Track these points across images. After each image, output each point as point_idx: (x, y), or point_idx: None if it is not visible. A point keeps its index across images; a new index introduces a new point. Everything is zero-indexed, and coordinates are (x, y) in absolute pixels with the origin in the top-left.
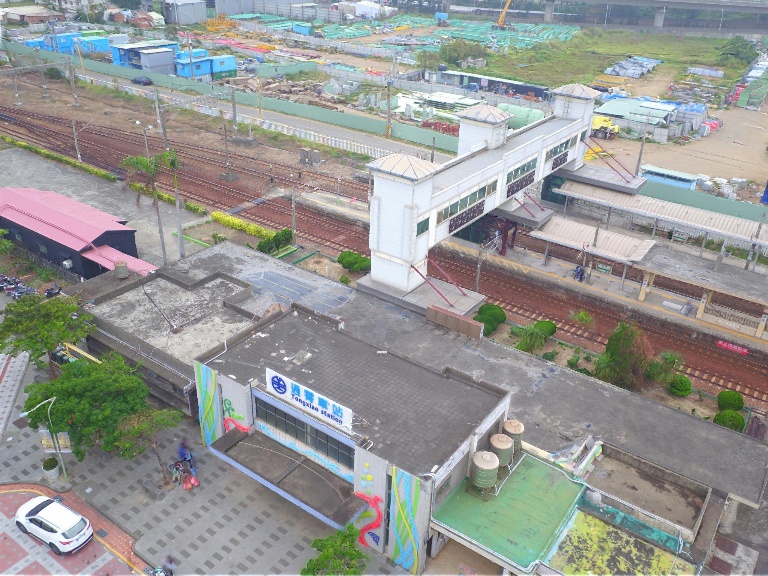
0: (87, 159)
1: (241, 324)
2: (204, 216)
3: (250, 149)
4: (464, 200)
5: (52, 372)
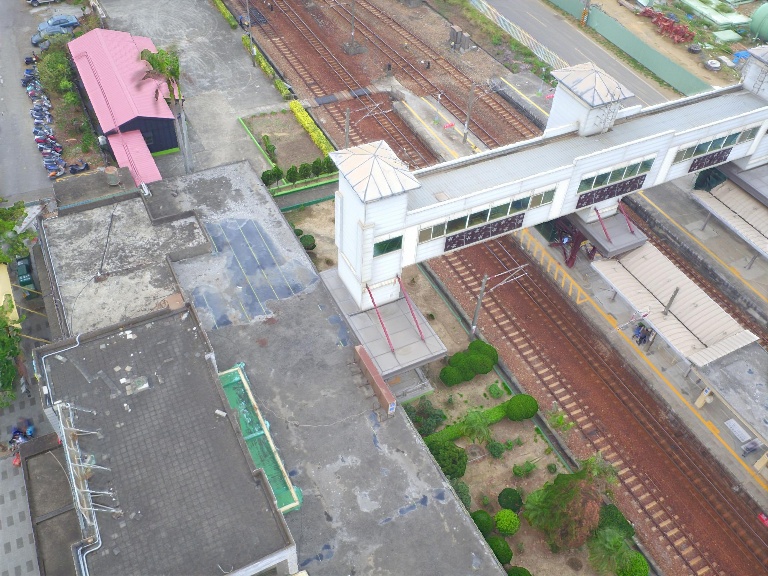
0: None
1: (163, 292)
2: (287, 101)
3: (408, 9)
4: (482, 213)
5: None
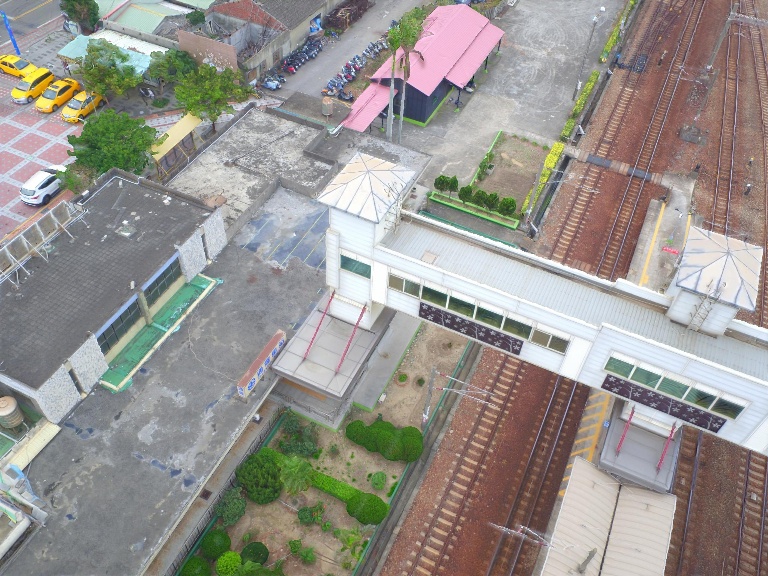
0: (652, 32)
1: (246, 199)
2: (561, 142)
3: None
4: None
5: (213, 131)
